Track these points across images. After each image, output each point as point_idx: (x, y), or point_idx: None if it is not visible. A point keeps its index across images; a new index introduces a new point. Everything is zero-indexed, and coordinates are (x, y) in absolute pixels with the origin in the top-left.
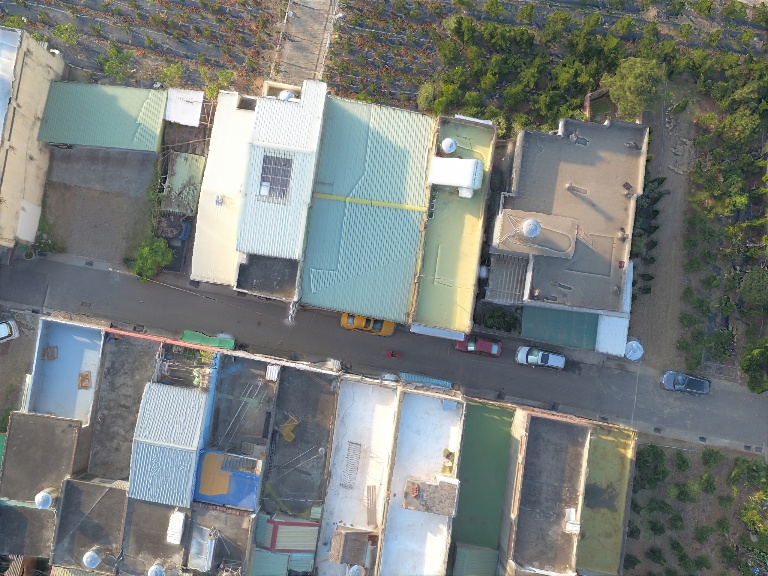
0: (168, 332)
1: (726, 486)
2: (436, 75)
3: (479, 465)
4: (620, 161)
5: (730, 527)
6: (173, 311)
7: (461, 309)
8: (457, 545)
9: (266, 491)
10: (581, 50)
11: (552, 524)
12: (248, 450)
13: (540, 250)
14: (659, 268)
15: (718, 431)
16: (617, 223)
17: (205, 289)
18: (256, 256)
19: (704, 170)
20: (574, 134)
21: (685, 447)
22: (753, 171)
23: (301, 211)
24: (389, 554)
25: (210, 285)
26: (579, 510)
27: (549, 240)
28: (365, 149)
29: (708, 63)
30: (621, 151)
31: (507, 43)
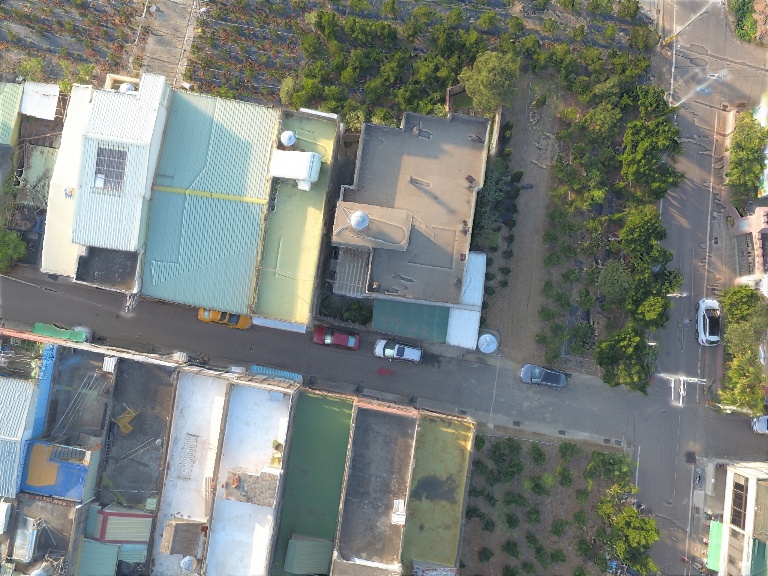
0: (26, 325)
1: (584, 479)
2: (300, 69)
3: (318, 457)
4: (464, 154)
5: (588, 520)
6: (31, 304)
7: (303, 301)
8: (292, 536)
9: (103, 482)
10: (442, 44)
11: (380, 515)
12: (85, 441)
13: (374, 242)
14: (520, 262)
15: (577, 424)
16: (460, 216)
17: (64, 282)
18: (98, 248)
19: None
20: (416, 127)
21: (544, 440)
22: (615, 165)
23: (136, 203)
24: (216, 545)
25: (69, 278)
26: (406, 501)
27: (383, 232)
28: (208, 142)
29: (568, 57)
30: (465, 144)
31: (368, 37)
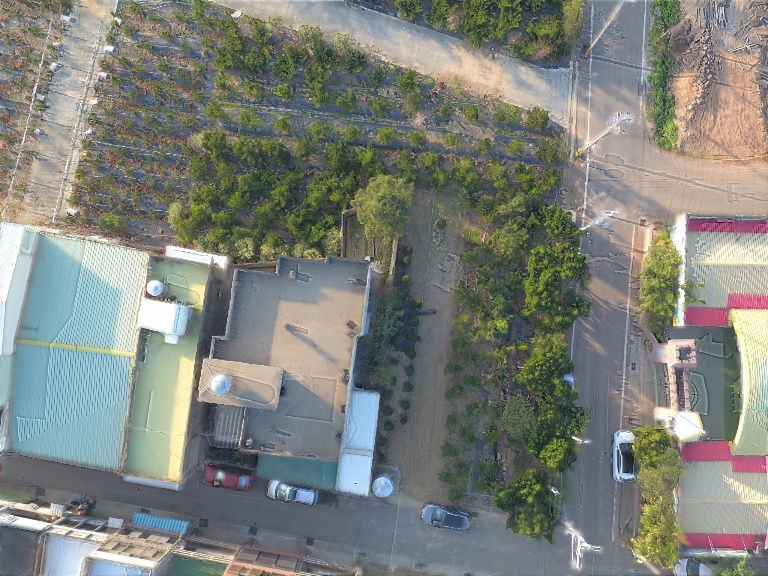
0: None
1: None
2: (190, 192)
3: None
4: (344, 298)
5: None
6: None
7: (175, 457)
8: None
9: None
10: (336, 165)
11: None
12: None
13: (242, 402)
14: (422, 393)
15: (484, 567)
16: (340, 364)
17: None
18: None
19: (472, 288)
20: (292, 272)
21: None
22: (522, 289)
23: None
24: None
25: None
26: None
27: (252, 391)
28: (75, 290)
29: (469, 177)
30: (346, 287)
31: (259, 159)
